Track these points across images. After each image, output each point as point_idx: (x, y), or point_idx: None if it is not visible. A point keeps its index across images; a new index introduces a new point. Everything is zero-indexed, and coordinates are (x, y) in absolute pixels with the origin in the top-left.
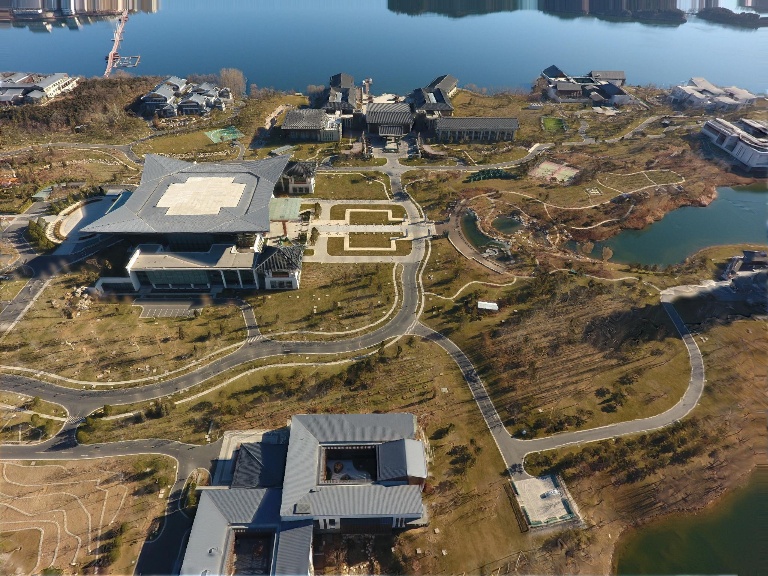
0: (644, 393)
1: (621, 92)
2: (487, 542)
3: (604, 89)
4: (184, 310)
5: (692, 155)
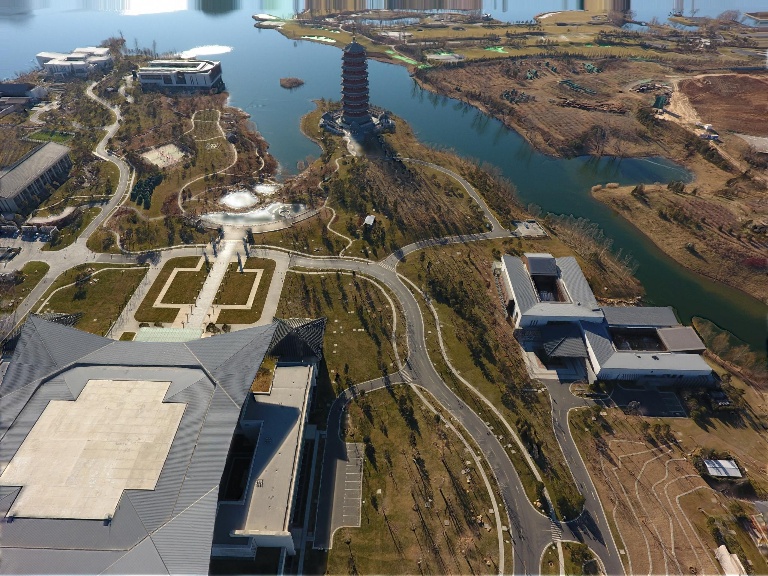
0: (446, 182)
1: (30, 85)
2: (563, 251)
3: (5, 91)
4: (348, 466)
5: (183, 96)
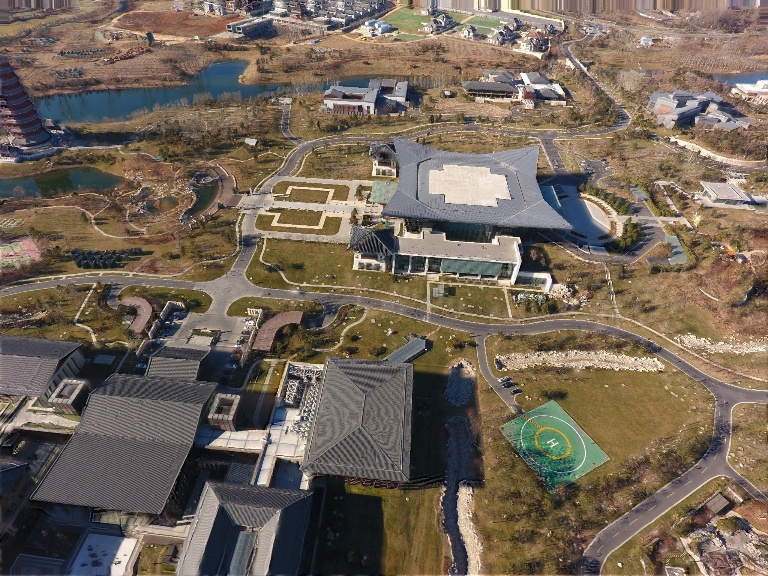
0: None
1: None
2: None
3: None
4: None
5: None
